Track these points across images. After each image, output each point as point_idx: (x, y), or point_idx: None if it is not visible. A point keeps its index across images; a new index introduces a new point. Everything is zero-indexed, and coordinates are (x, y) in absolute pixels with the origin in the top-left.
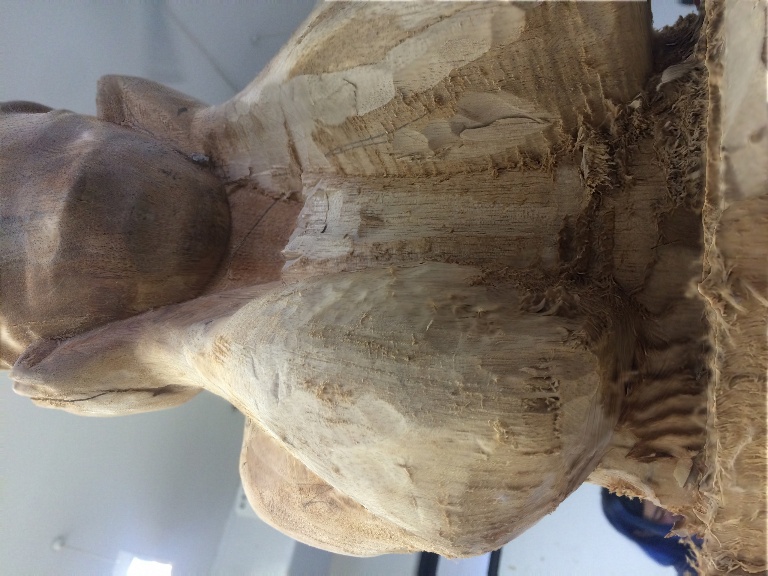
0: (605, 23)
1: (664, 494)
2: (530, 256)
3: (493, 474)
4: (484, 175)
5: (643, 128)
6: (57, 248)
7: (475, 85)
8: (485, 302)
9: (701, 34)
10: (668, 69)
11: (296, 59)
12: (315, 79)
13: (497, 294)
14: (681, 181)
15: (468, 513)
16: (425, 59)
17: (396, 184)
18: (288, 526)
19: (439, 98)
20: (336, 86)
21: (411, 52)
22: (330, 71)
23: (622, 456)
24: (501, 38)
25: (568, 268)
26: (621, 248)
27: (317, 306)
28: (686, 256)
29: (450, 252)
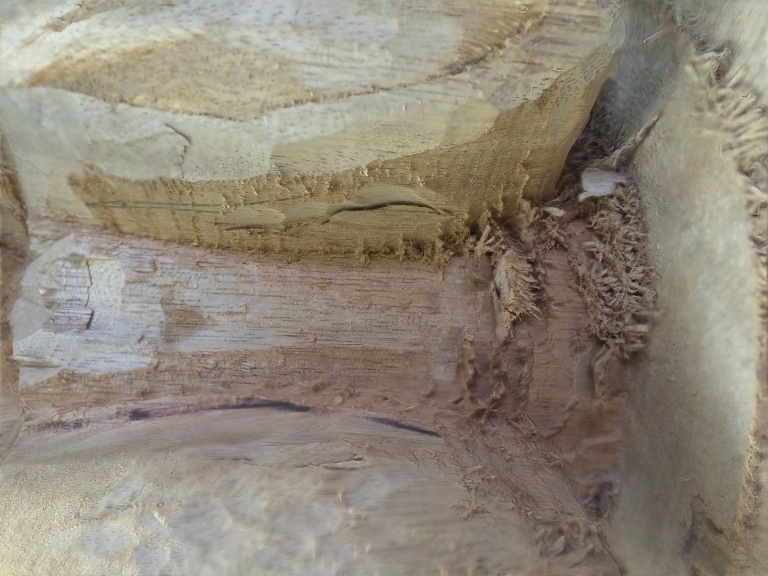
0: (563, 129)
1: None
2: (418, 374)
3: None
4: (349, 259)
5: (561, 241)
6: None
7: (393, 178)
8: (499, 553)
9: (629, 144)
10: (587, 173)
11: (50, 58)
12: (99, 107)
13: (501, 530)
14: (616, 325)
15: None
16: (335, 139)
17: (217, 260)
18: None
19: (334, 184)
20: (148, 130)
21: (314, 124)
22: (136, 104)
23: None
24: (455, 136)
25: (486, 409)
26: (538, 383)
27: (216, 556)
28: None
29: (313, 368)
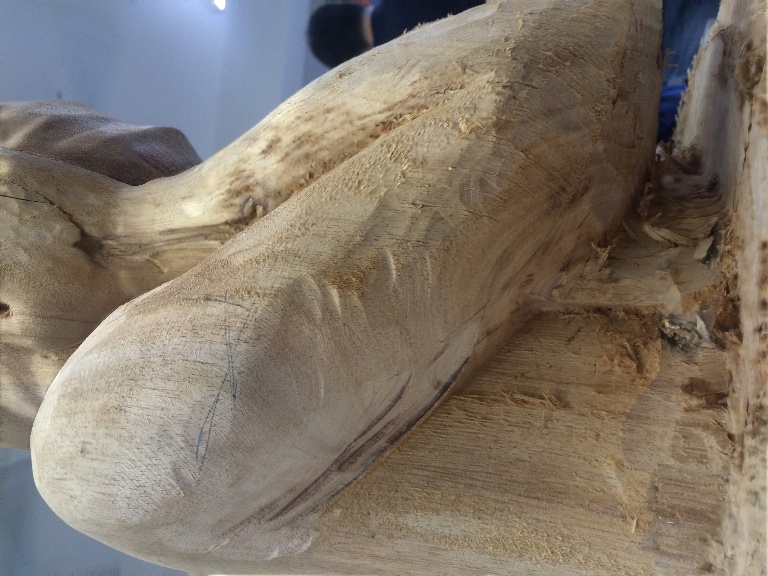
0: None
1: (683, 282)
2: None
3: (577, 0)
4: None
5: None
6: (133, 132)
7: None
8: None
9: None
10: None
11: None
12: None
13: None
14: None
15: (543, 21)
16: None
17: None
18: (155, 306)
19: None
20: None
21: None
22: None
23: (634, 266)
24: None
25: None
26: None
27: None
28: (685, 176)
29: None
